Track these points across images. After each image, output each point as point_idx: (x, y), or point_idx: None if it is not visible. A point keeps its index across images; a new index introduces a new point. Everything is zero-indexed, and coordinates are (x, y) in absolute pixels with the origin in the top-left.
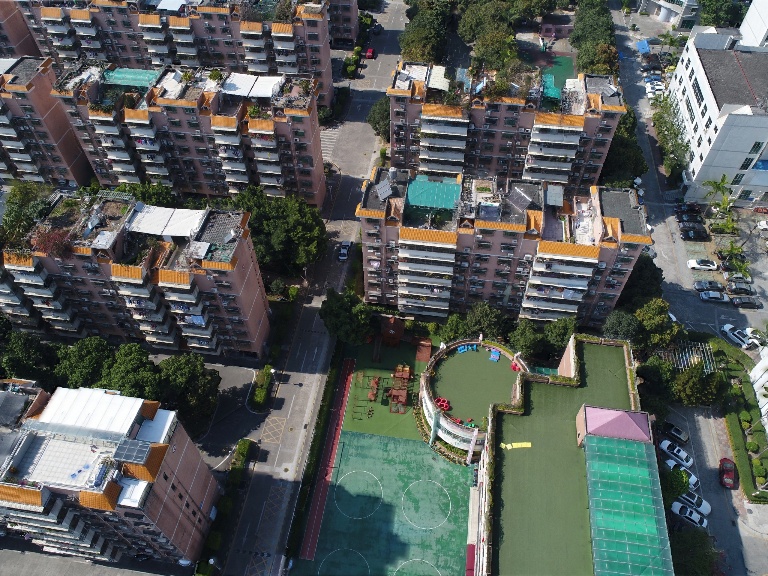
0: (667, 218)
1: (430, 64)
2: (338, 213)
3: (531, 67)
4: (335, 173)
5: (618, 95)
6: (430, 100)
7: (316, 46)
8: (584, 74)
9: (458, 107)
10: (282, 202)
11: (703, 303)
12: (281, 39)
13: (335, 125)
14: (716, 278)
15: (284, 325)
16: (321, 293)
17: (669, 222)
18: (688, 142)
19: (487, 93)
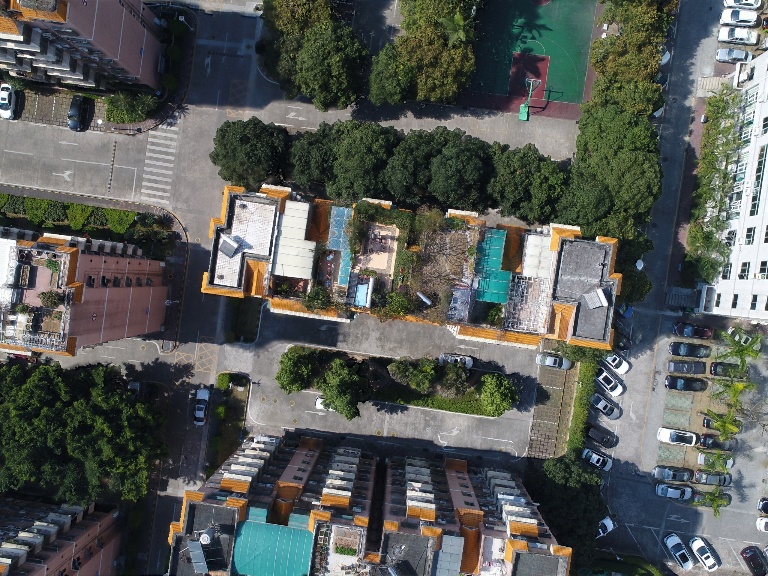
0: (658, 342)
1: (279, 203)
2: (189, 328)
3: (465, 225)
4: (179, 240)
5: (608, 303)
6: (281, 291)
7: (80, 40)
8: (561, 240)
9: (329, 307)
10: (86, 414)
11: (656, 496)
12: (4, 40)
13: (170, 115)
14: (688, 457)
15: (133, 545)
16: (177, 475)
17: (659, 350)
18: (732, 237)
19: (373, 313)
